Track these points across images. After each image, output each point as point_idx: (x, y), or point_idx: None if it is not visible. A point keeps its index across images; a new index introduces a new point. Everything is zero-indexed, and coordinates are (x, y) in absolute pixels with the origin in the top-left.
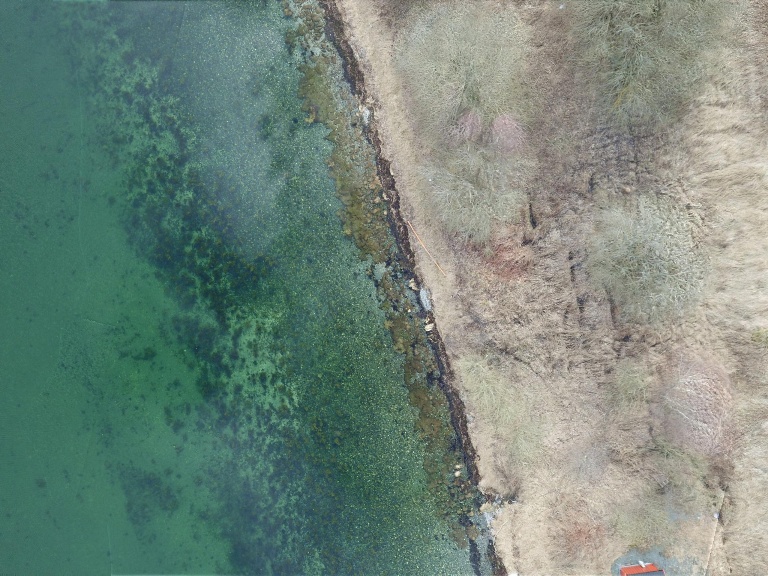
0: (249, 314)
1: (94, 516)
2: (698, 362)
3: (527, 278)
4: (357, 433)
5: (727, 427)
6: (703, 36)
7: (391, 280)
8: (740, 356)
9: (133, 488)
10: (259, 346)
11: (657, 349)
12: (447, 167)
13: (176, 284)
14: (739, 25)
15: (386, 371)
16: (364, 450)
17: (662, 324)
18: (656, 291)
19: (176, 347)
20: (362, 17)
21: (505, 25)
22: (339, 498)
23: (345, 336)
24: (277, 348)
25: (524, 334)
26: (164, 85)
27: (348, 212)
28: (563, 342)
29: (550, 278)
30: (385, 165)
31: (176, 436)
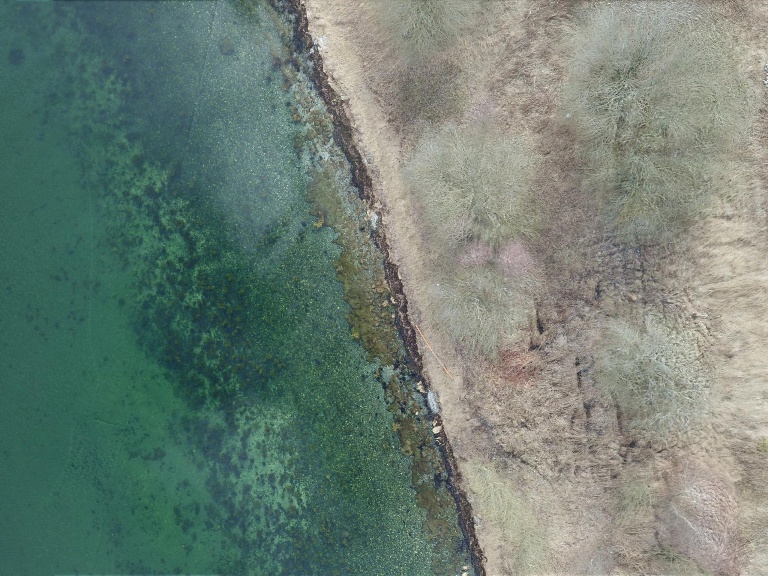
0: (258, 415)
1: None
2: (704, 469)
3: (534, 383)
4: (365, 533)
5: (733, 534)
6: (709, 149)
7: (399, 383)
8: (745, 465)
9: None
10: (268, 447)
11: (663, 455)
12: (455, 272)
13: (185, 385)
14: (745, 139)
15: (394, 472)
16: (372, 550)
17: (668, 431)
18: (663, 411)
19: (185, 447)
20: (370, 123)
21: (512, 132)
22: None
23: (353, 437)
24: (286, 449)
25: (531, 438)
26: (173, 189)
27: (356, 315)
28: (570, 447)
29: (557, 383)
30: (393, 269)
31: (185, 536)
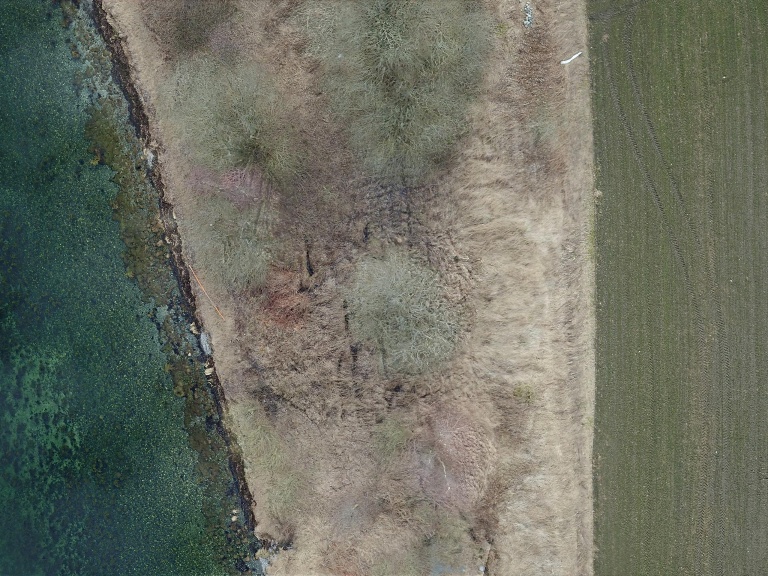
0: (33, 354)
1: None
2: (465, 414)
3: (303, 325)
4: (137, 475)
5: (492, 480)
6: (471, 90)
7: (173, 323)
8: (504, 410)
9: None
10: (43, 386)
11: (427, 400)
12: None
13: None
14: (504, 80)
15: (167, 414)
16: (144, 492)
17: (432, 375)
18: (398, 348)
19: None
20: (147, 61)
21: (285, 72)
22: (118, 540)
23: (127, 378)
24: (60, 388)
25: (300, 381)
26: None
27: (131, 254)
28: (337, 390)
29: (325, 326)
30: (168, 209)
31: None
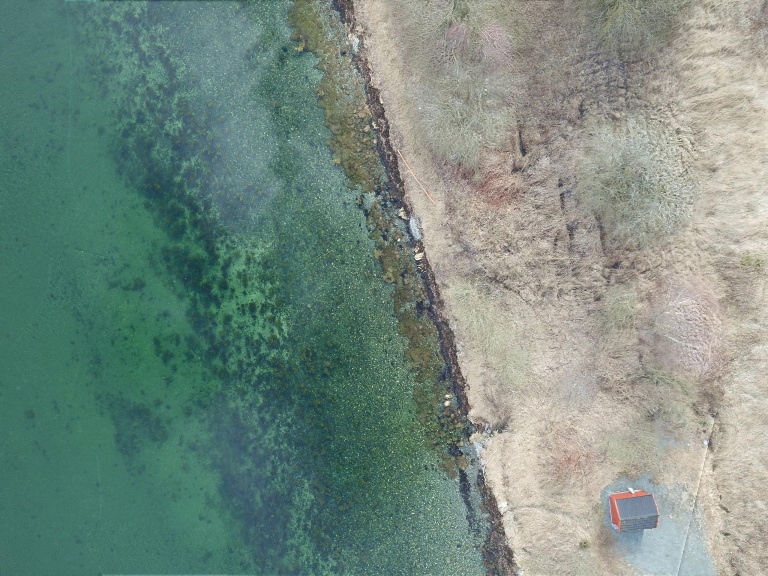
0: (238, 244)
1: (83, 447)
2: (688, 288)
3: (517, 206)
4: (347, 363)
5: (717, 353)
6: None
7: (381, 209)
8: (730, 281)
9: (122, 419)
10: (248, 276)
11: (647, 276)
12: (437, 95)
13: (165, 214)
14: None
15: (376, 301)
16: (354, 380)
17: (652, 250)
18: (644, 208)
19: (165, 278)
20: None
21: None
22: (329, 428)
23: (335, 266)
24: (266, 278)
25: (514, 262)
26: (153, 14)
27: (338, 141)
28: (553, 270)
29: (540, 205)
30: (375, 94)
31: (165, 367)
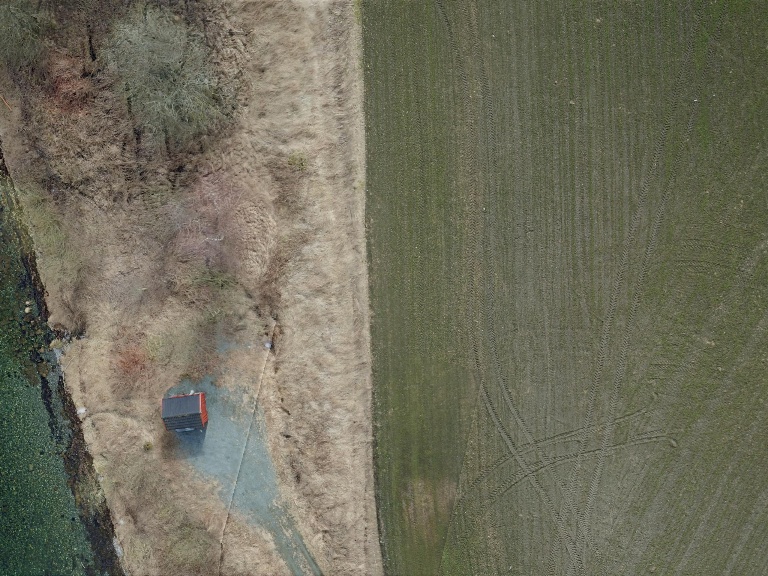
0: None
1: None
2: (246, 190)
3: (88, 111)
4: None
5: (273, 254)
6: None
7: None
8: (281, 181)
9: None
10: None
11: (209, 179)
12: (9, 0)
13: None
14: None
15: None
16: None
17: (213, 153)
18: (152, 99)
19: None
20: None
21: None
22: None
23: None
24: None
25: (87, 168)
26: None
27: None
28: (122, 174)
29: (109, 110)
30: None
31: None
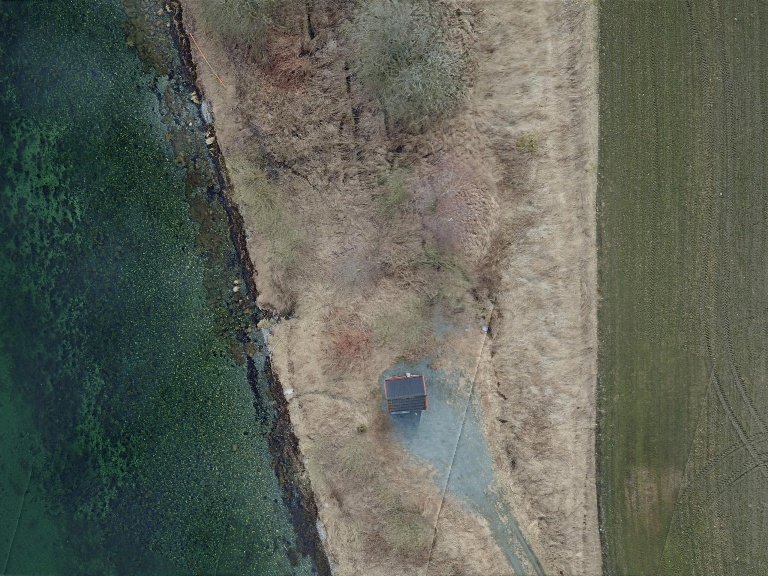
0: (34, 127)
1: None
2: (468, 171)
3: (305, 90)
4: (138, 248)
5: (495, 237)
6: None
7: (173, 93)
8: (506, 163)
9: None
10: (43, 159)
11: (429, 160)
12: None
13: None
14: None
15: (168, 185)
16: (145, 265)
17: (434, 134)
18: (400, 77)
19: None
20: None
21: None
22: (119, 313)
23: (128, 150)
24: (60, 161)
25: (301, 147)
26: None
27: (132, 24)
28: (338, 154)
29: (327, 89)
30: None
31: None
